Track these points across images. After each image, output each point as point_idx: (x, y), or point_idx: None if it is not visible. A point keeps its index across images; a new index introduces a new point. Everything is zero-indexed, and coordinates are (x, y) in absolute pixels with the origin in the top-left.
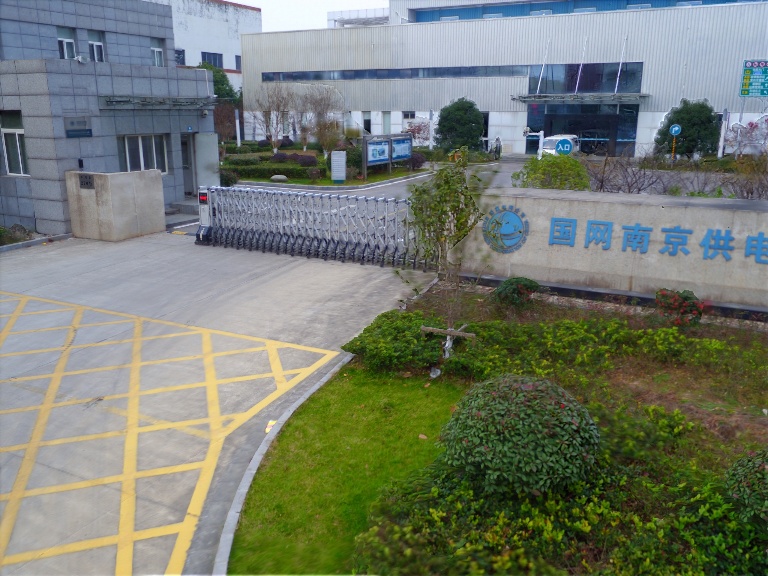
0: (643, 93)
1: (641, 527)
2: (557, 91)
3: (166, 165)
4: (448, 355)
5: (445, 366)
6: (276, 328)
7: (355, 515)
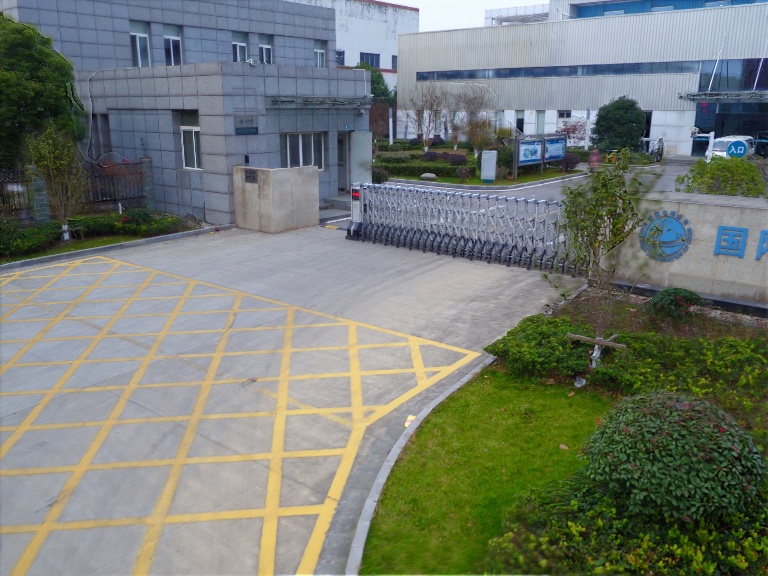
0: None
1: None
2: (732, 88)
3: (323, 162)
4: (595, 365)
5: (591, 376)
6: (419, 325)
7: (490, 518)
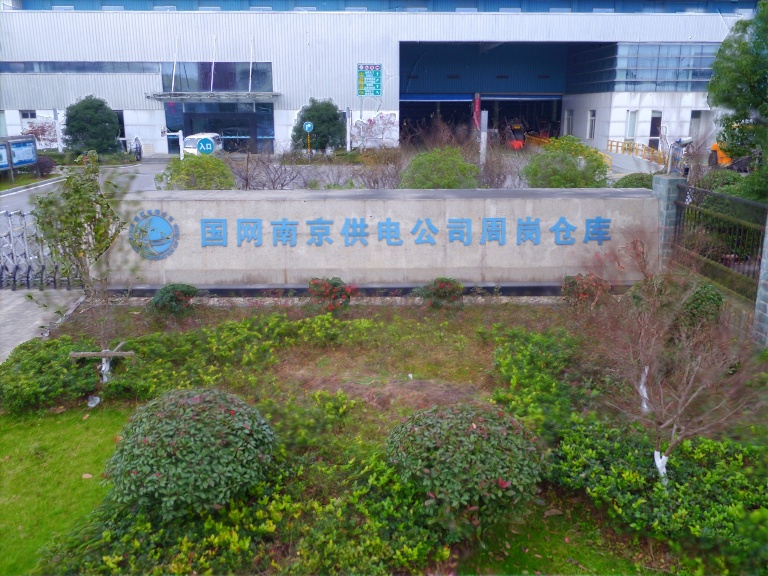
0: (275, 92)
1: (321, 511)
2: (192, 89)
3: None
4: (106, 379)
5: (104, 392)
6: None
7: None
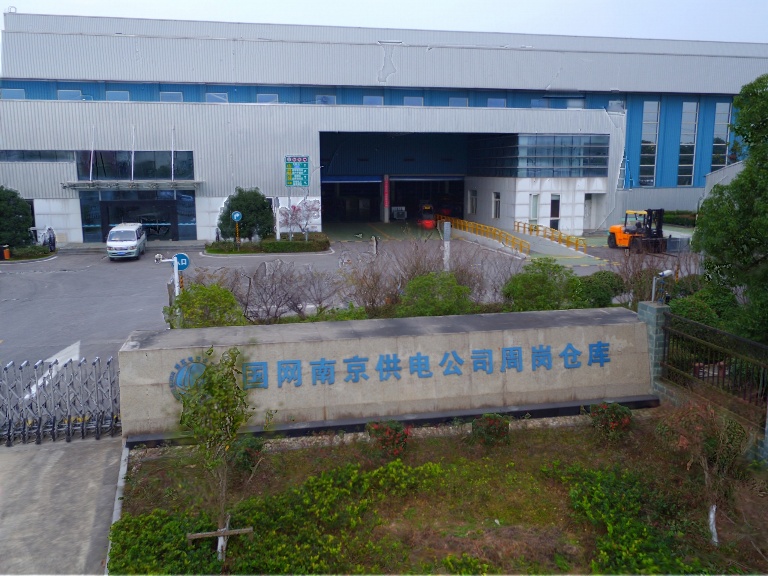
0: (197, 180)
1: None
2: (110, 177)
3: None
4: (224, 557)
5: (235, 575)
6: None
7: None
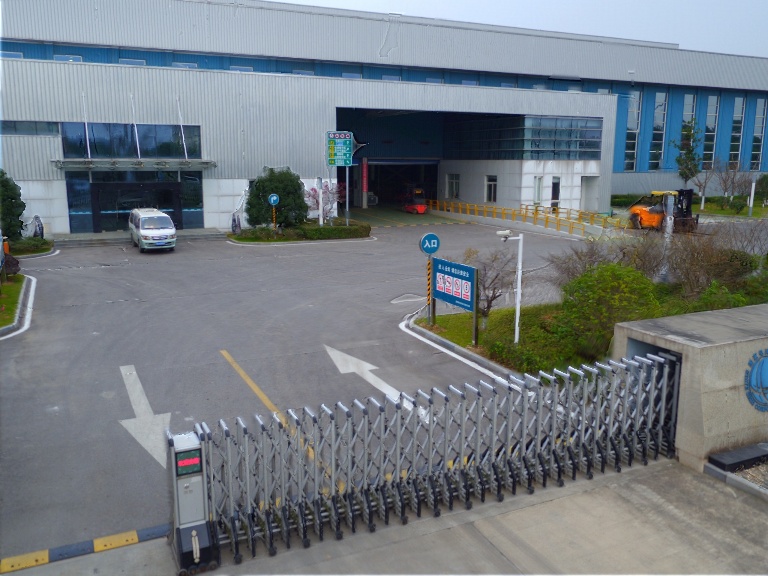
0: (205, 159)
1: None
2: (103, 155)
3: None
4: None
5: None
6: None
7: None
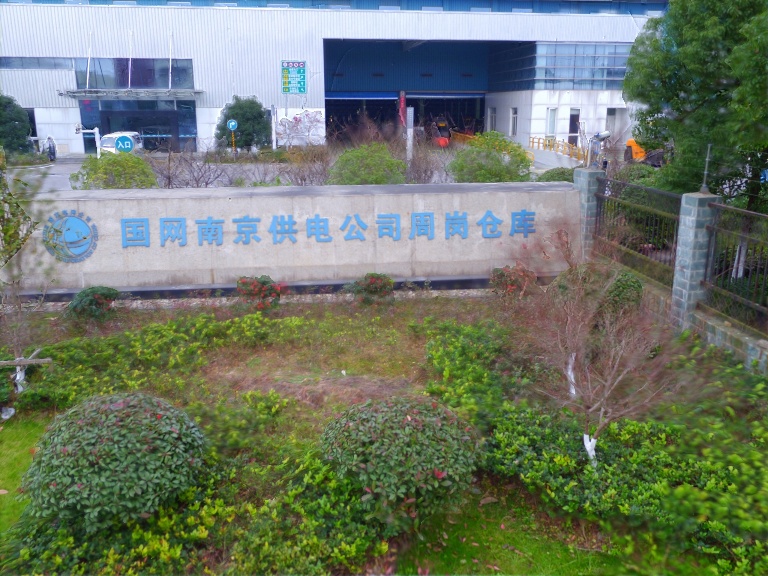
0: (197, 89)
1: (256, 514)
2: (109, 86)
3: None
4: (21, 389)
5: (19, 402)
6: None
7: None
